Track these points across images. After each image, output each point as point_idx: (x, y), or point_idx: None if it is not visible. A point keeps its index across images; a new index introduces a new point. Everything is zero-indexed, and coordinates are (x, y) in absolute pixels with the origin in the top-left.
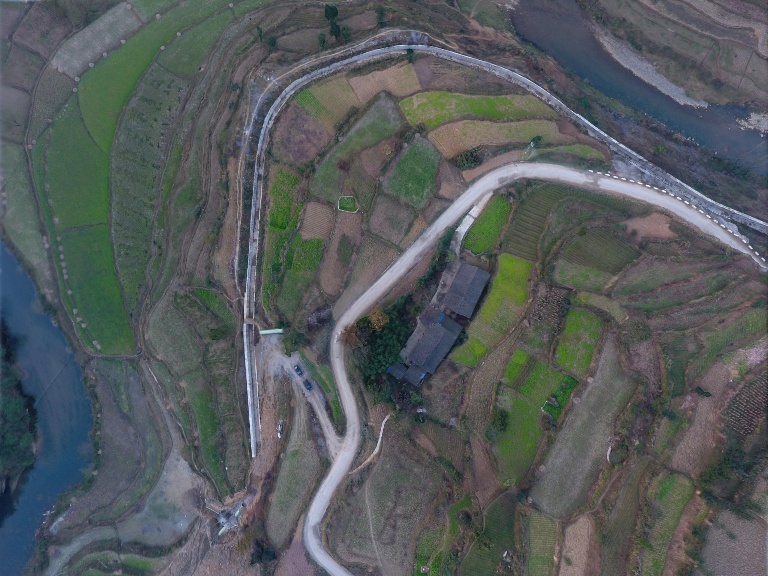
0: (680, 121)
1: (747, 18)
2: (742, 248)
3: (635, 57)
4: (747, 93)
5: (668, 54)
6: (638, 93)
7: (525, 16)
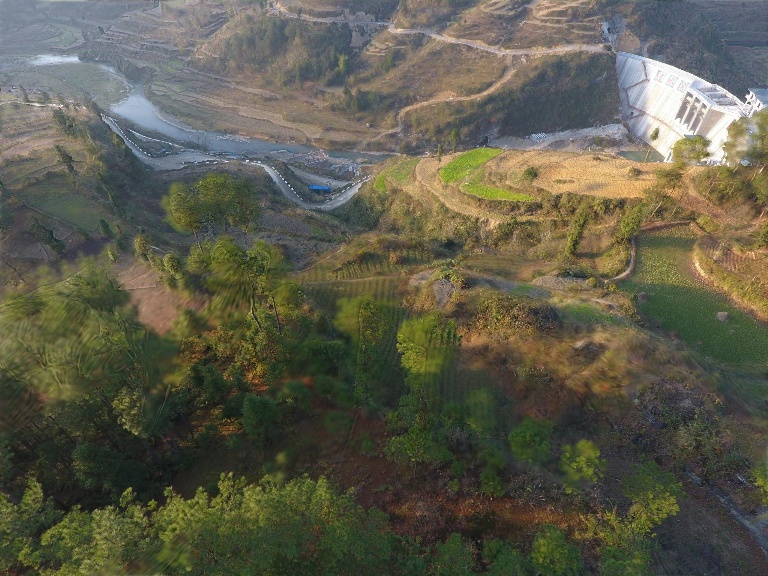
0: (183, 137)
1: (238, 105)
2: (108, 121)
3: (172, 118)
4: (225, 126)
5: (190, 116)
6: (165, 128)
7: (121, 107)
